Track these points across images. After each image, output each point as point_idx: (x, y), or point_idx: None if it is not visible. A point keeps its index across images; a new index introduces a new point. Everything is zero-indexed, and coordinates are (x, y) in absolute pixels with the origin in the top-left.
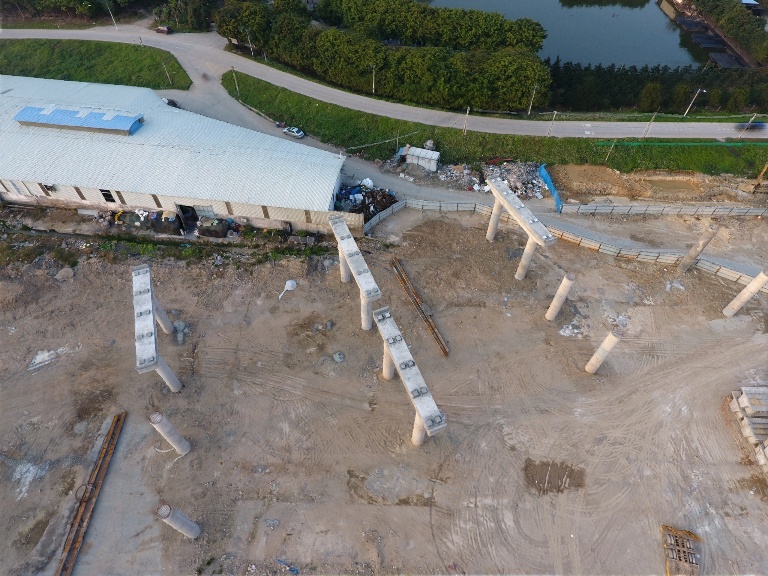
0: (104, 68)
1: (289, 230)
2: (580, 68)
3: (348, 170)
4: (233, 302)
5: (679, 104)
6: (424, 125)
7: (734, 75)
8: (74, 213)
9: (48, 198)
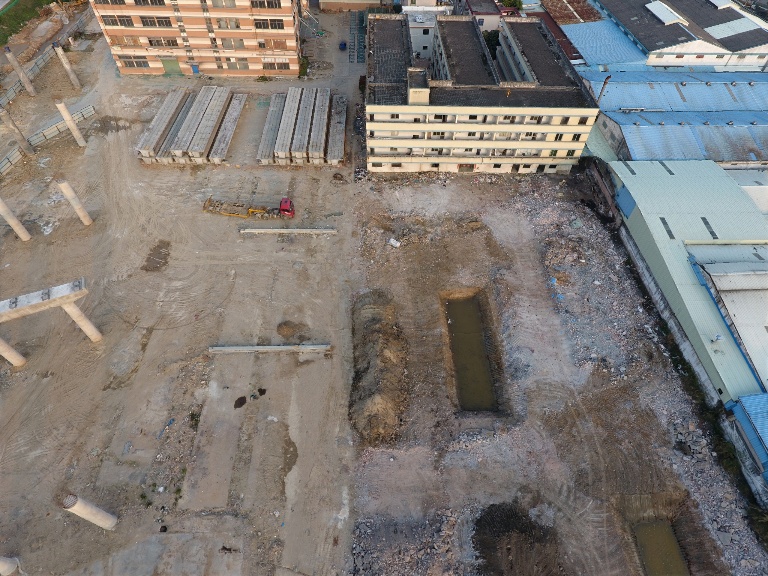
0: None
1: None
2: None
3: None
4: None
5: None
6: None
7: None
8: None
9: None
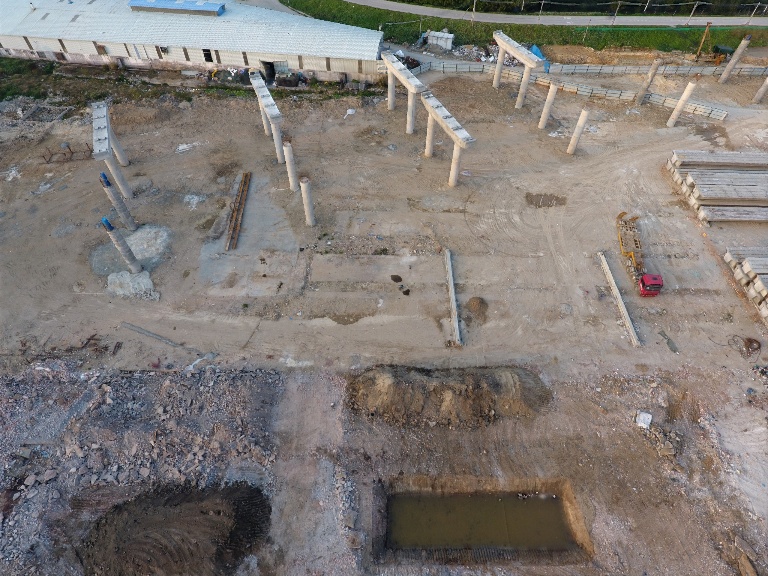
0: None
1: (345, 81)
2: None
3: None
4: (311, 120)
5: (642, 6)
6: (440, 18)
7: None
8: (179, 74)
9: (160, 61)
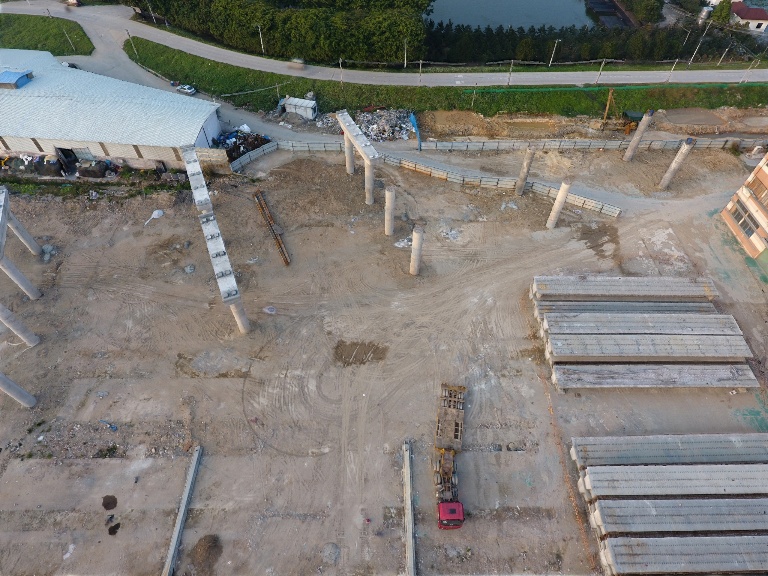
0: (12, 38)
1: (163, 169)
2: (470, 30)
3: (232, 120)
4: (101, 229)
5: None
6: (306, 79)
7: (612, 33)
8: None
9: None
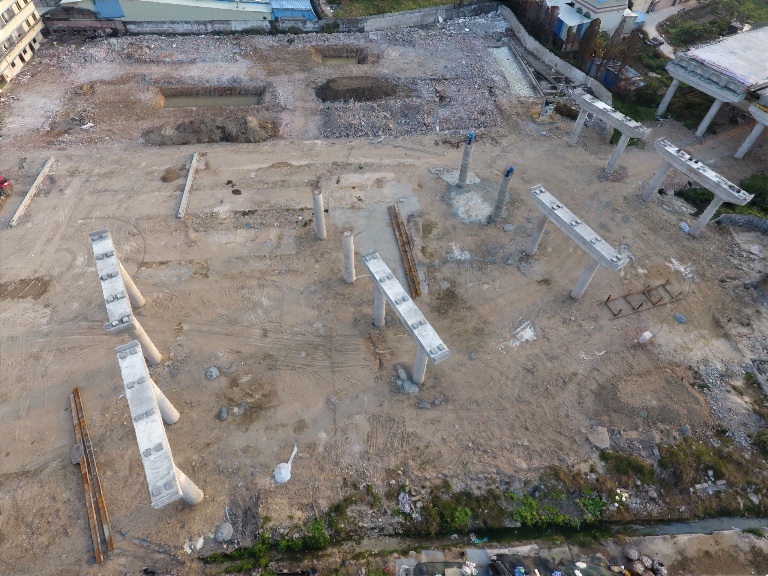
0: None
1: None
2: None
3: None
4: (358, 430)
5: None
6: None
7: None
8: None
9: None
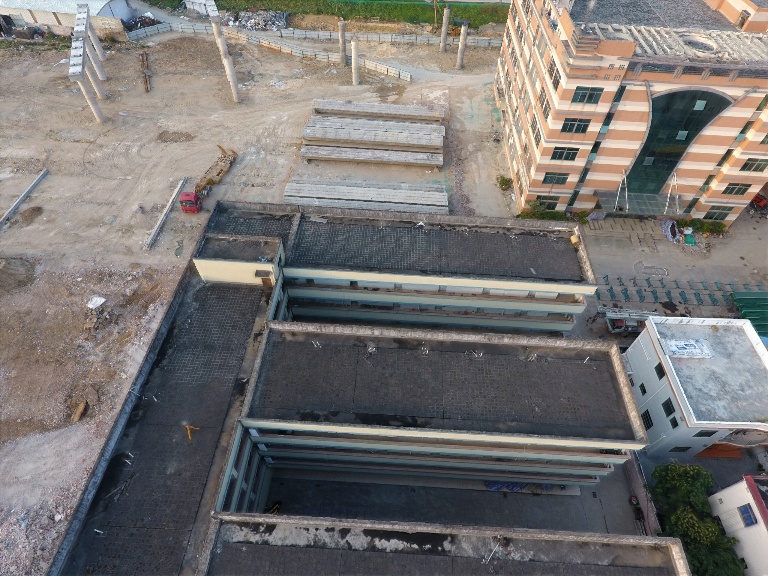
0: None
1: None
2: None
3: (144, 13)
4: (21, 66)
5: None
6: None
7: None
8: None
9: None
